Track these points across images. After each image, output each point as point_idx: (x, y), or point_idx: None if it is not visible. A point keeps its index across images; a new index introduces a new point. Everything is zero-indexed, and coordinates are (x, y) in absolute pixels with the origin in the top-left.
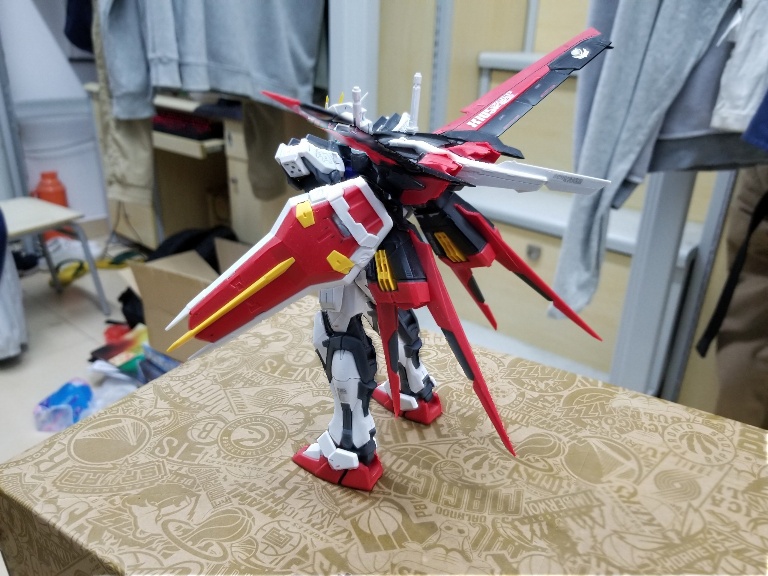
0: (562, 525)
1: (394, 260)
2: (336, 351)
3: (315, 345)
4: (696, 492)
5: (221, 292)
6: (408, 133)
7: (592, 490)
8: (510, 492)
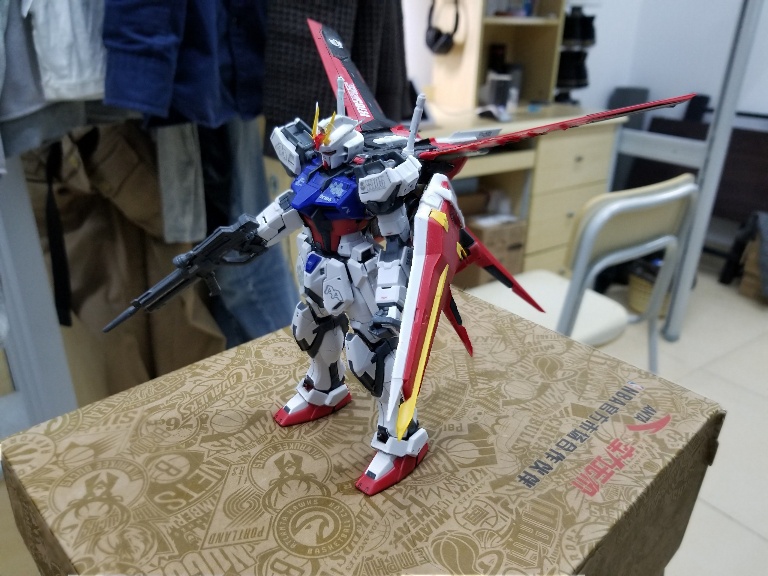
0: (481, 370)
1: (460, 233)
2: (386, 357)
3: (363, 370)
4: (464, 316)
5: (419, 336)
6: None
7: (452, 349)
8: (445, 382)
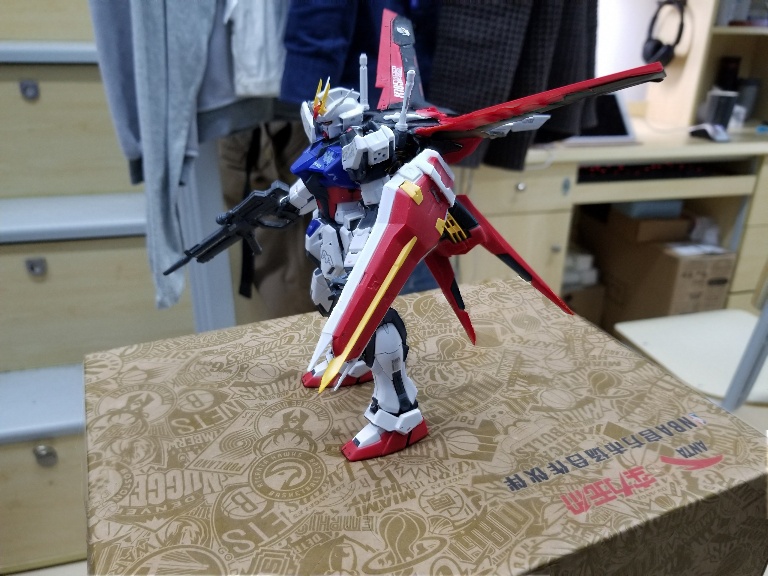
0: (525, 373)
1: (460, 214)
2: (378, 329)
3: None
4: (536, 320)
5: (361, 299)
6: None
7: (506, 349)
8: (481, 377)
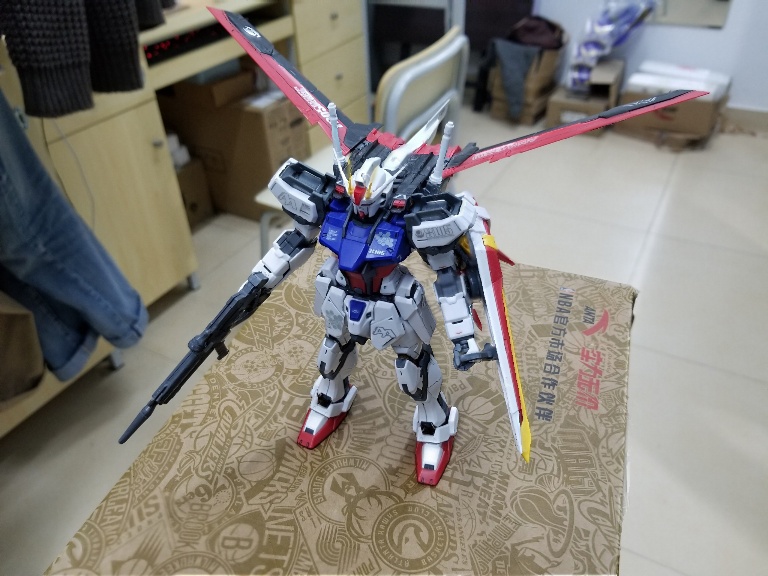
0: (442, 318)
1: None
2: (428, 366)
3: None
4: None
5: None
6: (350, 162)
7: None
8: None
